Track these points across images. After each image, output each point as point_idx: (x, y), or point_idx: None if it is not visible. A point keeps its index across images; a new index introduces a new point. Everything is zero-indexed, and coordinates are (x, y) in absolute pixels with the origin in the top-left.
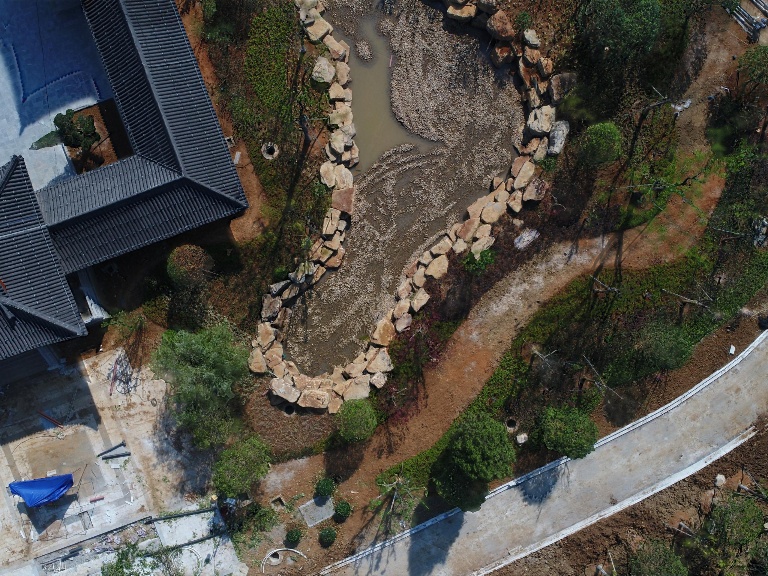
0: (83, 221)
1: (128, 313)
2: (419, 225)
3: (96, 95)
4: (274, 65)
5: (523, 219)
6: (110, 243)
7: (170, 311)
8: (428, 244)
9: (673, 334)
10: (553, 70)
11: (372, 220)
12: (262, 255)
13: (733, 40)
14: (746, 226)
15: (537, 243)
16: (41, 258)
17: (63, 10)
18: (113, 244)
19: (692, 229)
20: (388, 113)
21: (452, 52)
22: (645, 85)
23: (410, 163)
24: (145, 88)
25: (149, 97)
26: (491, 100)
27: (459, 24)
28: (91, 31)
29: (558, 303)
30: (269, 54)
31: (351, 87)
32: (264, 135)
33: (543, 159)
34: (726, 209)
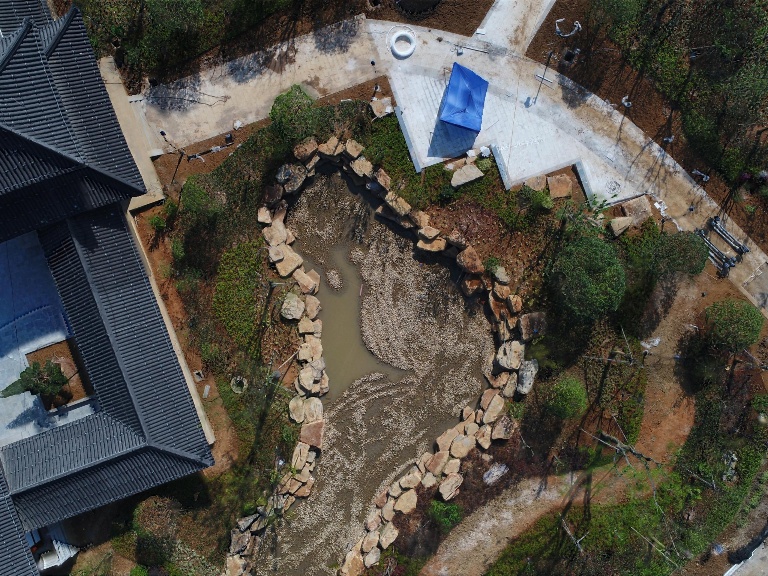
0: (47, 486)
1: (96, 546)
2: (389, 454)
3: (65, 329)
4: (243, 301)
5: (492, 454)
6: (75, 502)
7: (138, 546)
8: (398, 473)
9: (642, 572)
10: (522, 307)
11: (342, 448)
12: (231, 490)
13: (703, 276)
14: (715, 462)
15: (506, 479)
16: (4, 529)
17: (32, 246)
18: (78, 502)
19: (661, 466)
20: (358, 341)
21: (422, 281)
22: (614, 323)
23: (380, 392)
24: (110, 352)
25: (114, 361)
26: (461, 329)
27: (429, 253)
28: (57, 289)
29: (527, 541)
30: (238, 290)
31: (321, 315)
32: (233, 369)
33: (512, 394)
34: (695, 447)
